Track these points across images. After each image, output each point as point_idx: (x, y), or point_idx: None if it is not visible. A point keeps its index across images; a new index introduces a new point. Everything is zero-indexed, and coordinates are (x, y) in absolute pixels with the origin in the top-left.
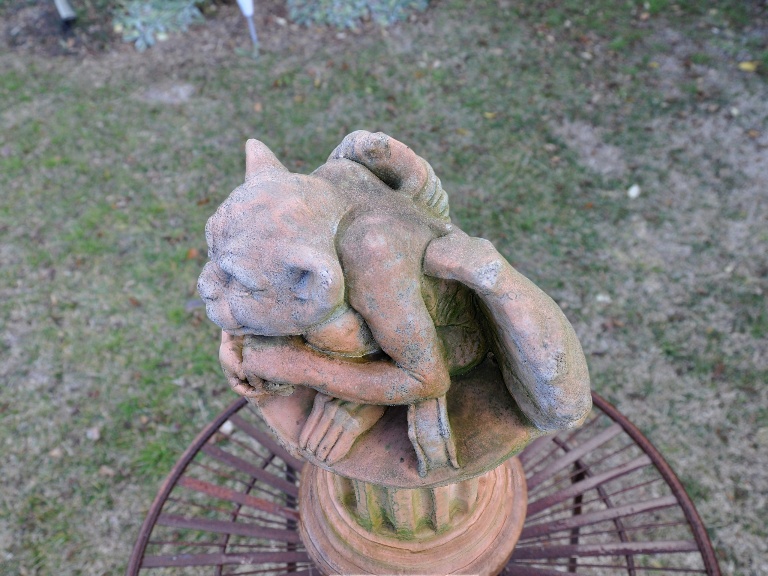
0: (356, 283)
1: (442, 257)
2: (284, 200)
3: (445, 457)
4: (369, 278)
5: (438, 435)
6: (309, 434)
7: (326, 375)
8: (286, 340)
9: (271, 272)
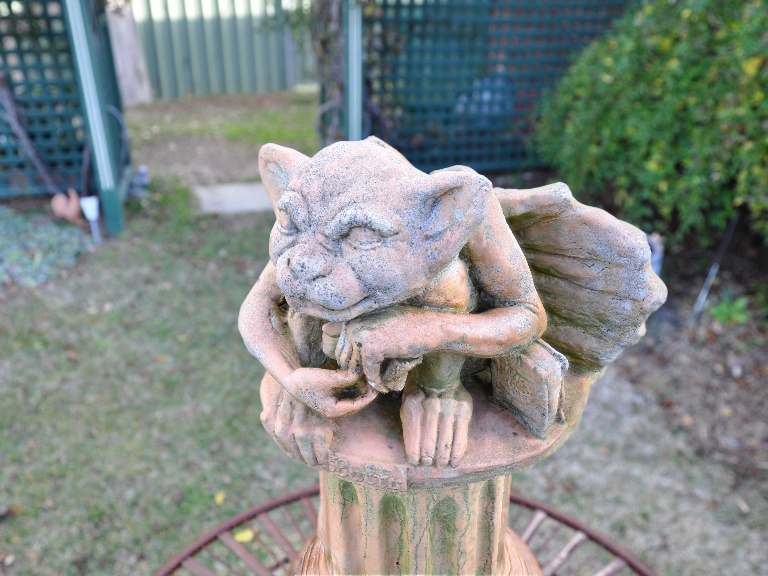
0: None
1: (510, 195)
2: (382, 150)
3: (557, 406)
4: None
5: (560, 368)
6: (419, 442)
7: (462, 325)
8: (403, 309)
9: (404, 210)
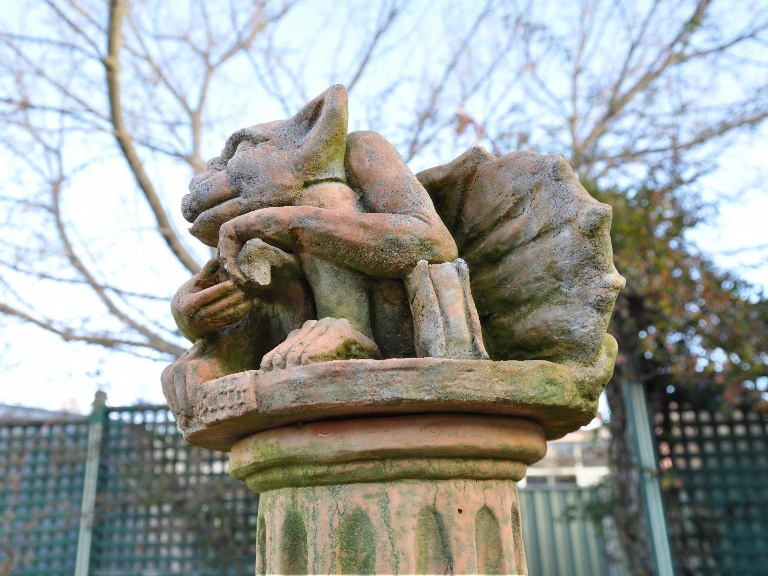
0: (357, 141)
1: None
2: None
3: (467, 329)
4: (369, 138)
5: (454, 268)
6: None
7: None
8: None
9: (280, 128)
